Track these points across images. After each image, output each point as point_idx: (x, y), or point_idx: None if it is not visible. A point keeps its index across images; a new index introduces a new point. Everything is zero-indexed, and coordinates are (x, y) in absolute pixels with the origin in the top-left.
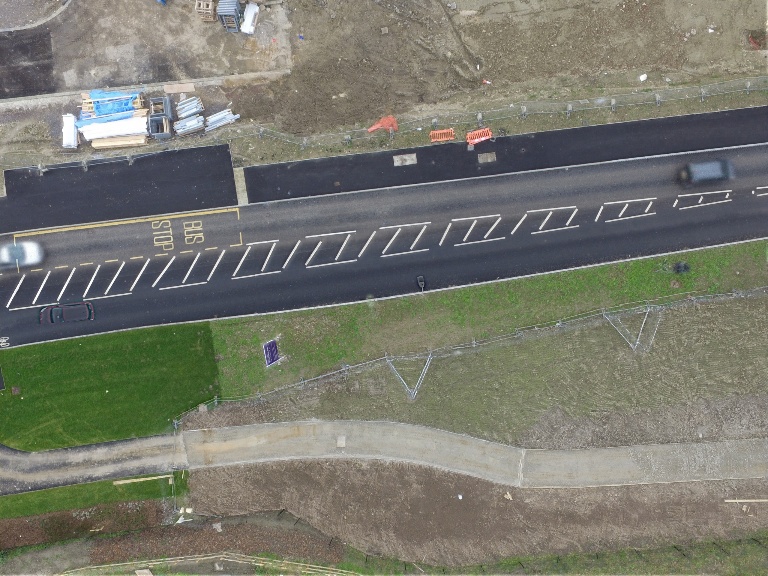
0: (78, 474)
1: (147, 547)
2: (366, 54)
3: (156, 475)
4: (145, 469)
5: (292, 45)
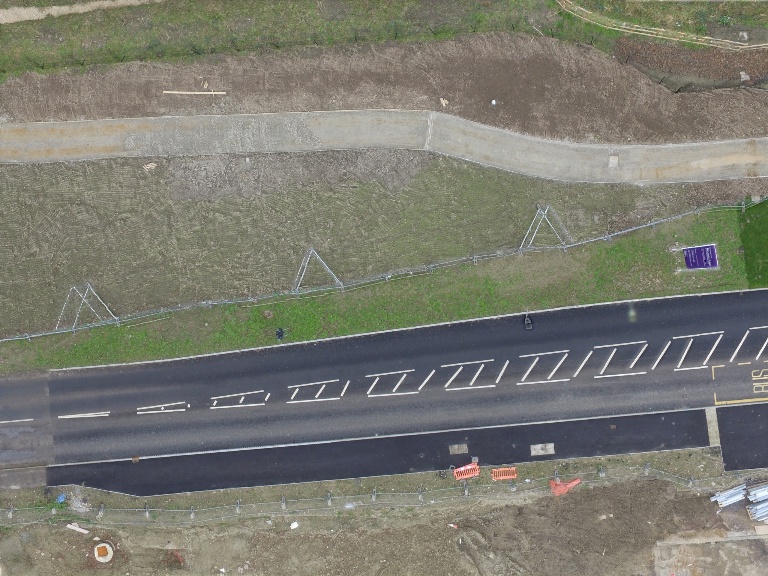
0: None
1: None
2: (576, 558)
3: None
4: None
5: (653, 570)
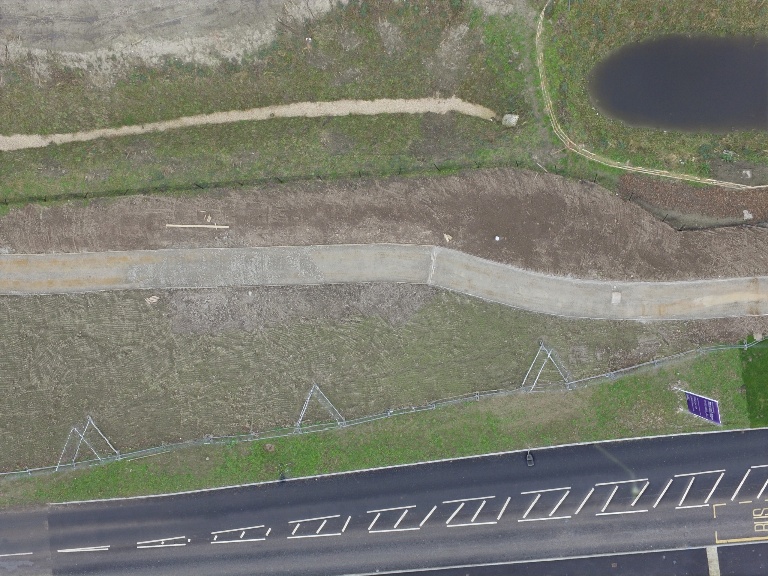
0: None
1: None
2: None
3: None
4: None
5: None
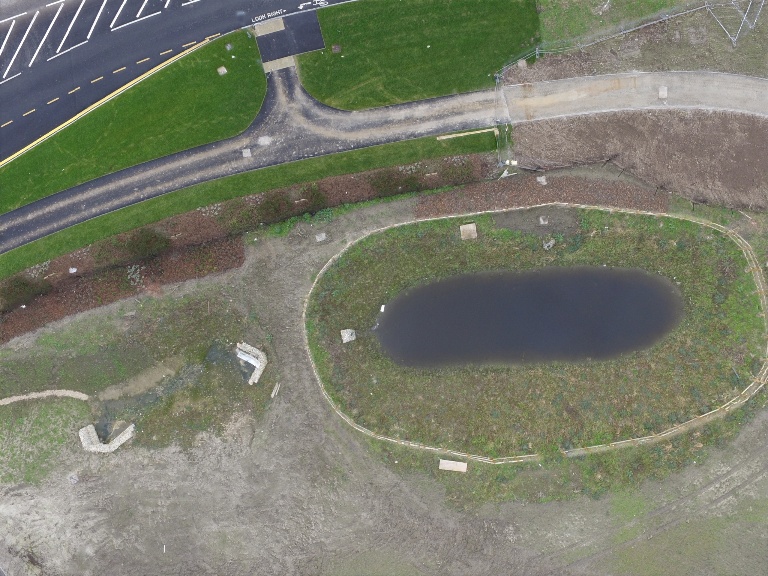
0: (400, 131)
1: (471, 203)
2: None
3: (480, 129)
4: (468, 124)
5: None
